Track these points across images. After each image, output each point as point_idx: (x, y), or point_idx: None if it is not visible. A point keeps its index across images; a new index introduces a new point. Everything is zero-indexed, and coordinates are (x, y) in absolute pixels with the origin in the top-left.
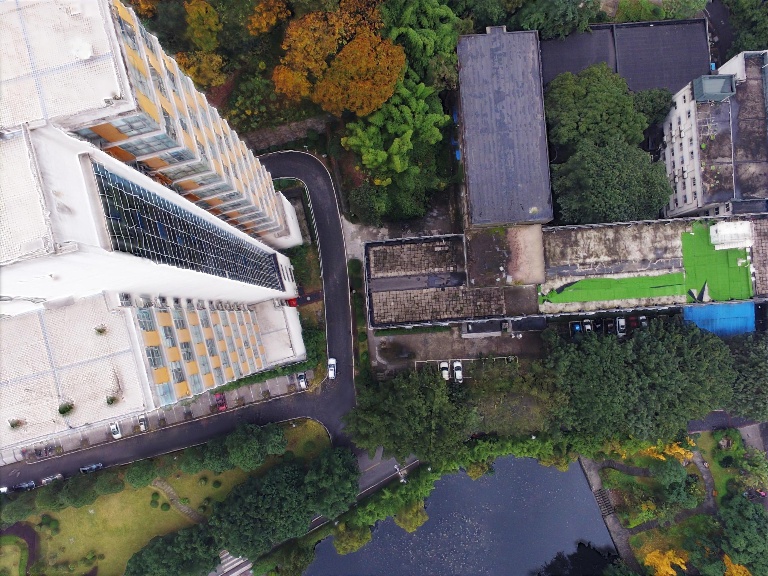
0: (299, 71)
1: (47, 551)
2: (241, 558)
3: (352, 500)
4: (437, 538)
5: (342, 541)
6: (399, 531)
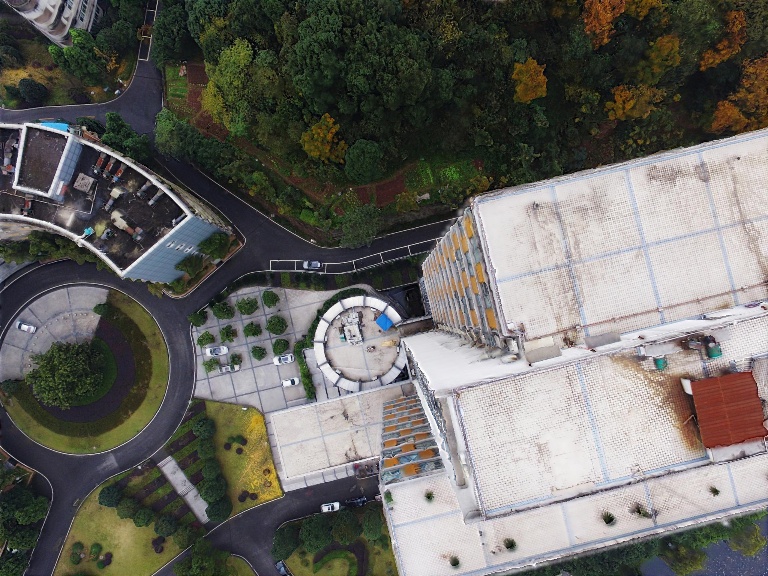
0: (740, 107)
1: (374, 565)
2: (562, 575)
3: (702, 524)
4: (750, 560)
5: (685, 563)
6: (713, 552)
